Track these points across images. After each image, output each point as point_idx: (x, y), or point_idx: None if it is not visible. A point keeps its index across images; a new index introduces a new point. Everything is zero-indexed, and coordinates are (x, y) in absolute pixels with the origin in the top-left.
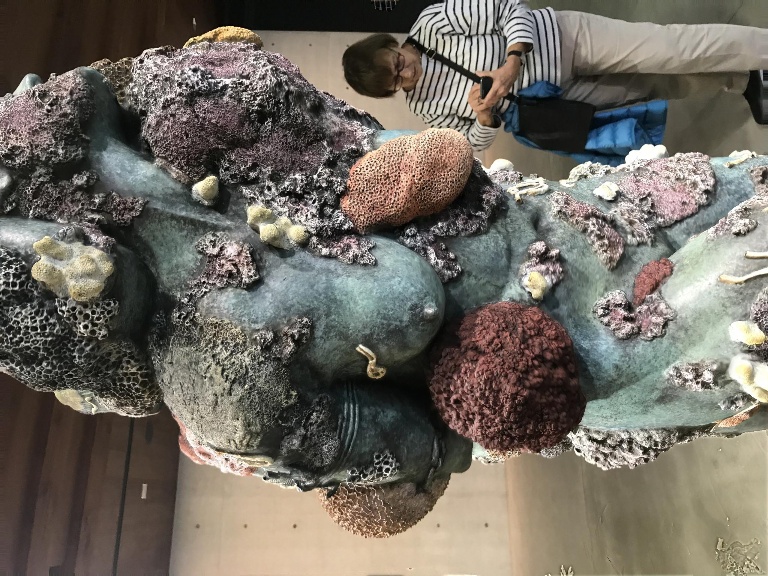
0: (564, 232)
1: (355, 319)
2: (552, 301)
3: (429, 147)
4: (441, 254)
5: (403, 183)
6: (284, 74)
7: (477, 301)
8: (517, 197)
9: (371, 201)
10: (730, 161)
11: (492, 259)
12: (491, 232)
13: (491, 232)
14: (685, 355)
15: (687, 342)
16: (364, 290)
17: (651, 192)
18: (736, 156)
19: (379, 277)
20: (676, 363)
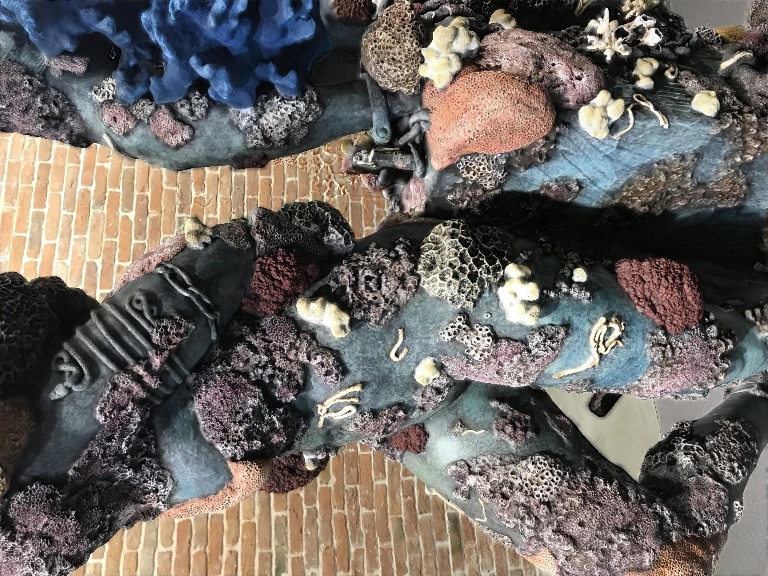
0: None
1: None
2: None
3: None
4: None
5: None
6: (70, 569)
7: None
8: (321, 421)
9: None
10: (565, 370)
11: None
12: None
13: None
14: None
15: None
16: None
17: None
18: (585, 355)
19: None
20: None
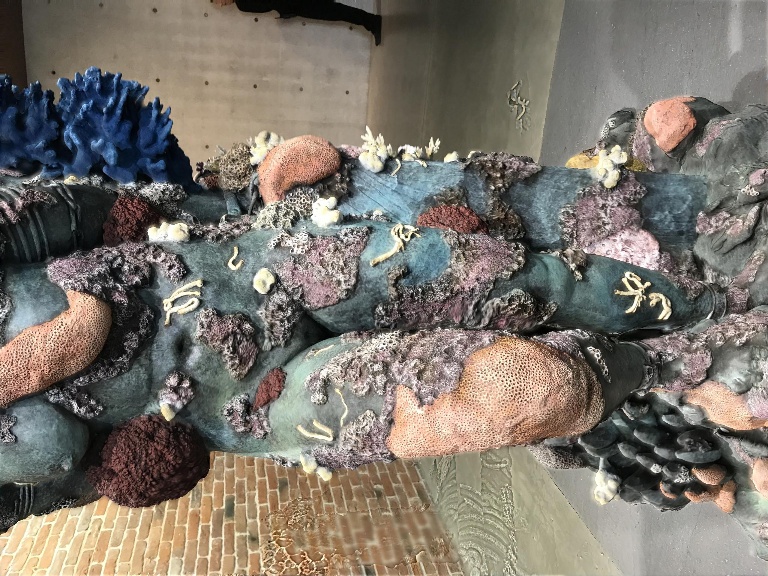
0: (202, 356)
1: (5, 475)
2: (185, 413)
3: (55, 345)
4: (84, 401)
5: (33, 378)
6: None
7: (122, 417)
8: (167, 318)
9: (7, 390)
10: (378, 256)
11: (133, 392)
12: (133, 368)
13: (133, 368)
14: (277, 452)
15: (278, 447)
16: (8, 461)
17: (303, 284)
18: (390, 242)
19: (20, 451)
20: (272, 453)
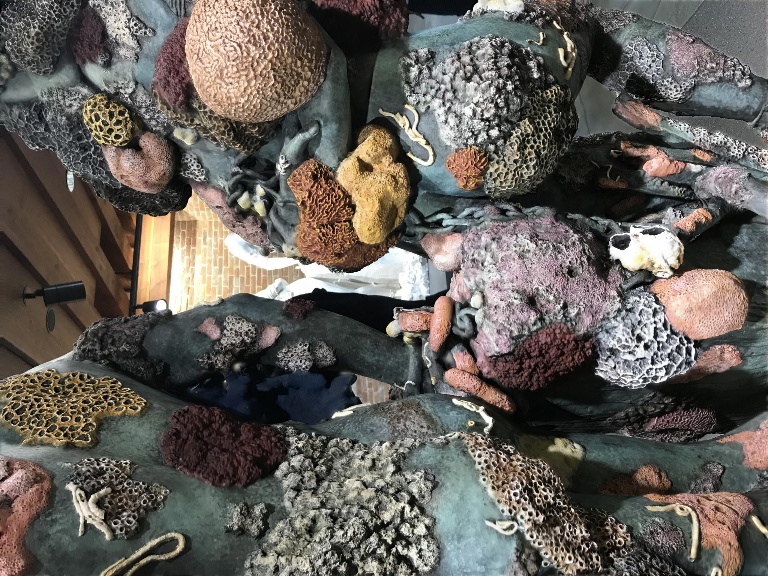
0: None
1: None
2: None
3: None
4: None
5: None
6: None
7: None
8: None
9: None
10: None
11: None
12: None
13: None
14: None
15: None
16: None
17: None
18: None
19: None
20: None
